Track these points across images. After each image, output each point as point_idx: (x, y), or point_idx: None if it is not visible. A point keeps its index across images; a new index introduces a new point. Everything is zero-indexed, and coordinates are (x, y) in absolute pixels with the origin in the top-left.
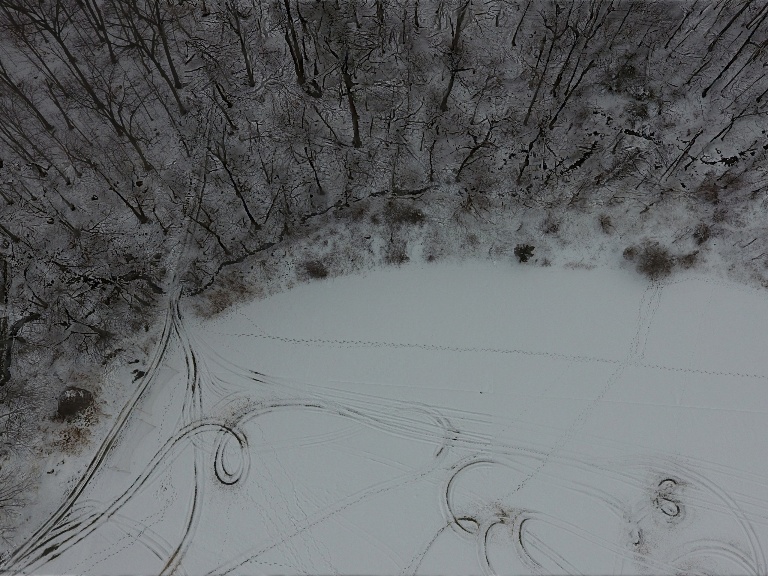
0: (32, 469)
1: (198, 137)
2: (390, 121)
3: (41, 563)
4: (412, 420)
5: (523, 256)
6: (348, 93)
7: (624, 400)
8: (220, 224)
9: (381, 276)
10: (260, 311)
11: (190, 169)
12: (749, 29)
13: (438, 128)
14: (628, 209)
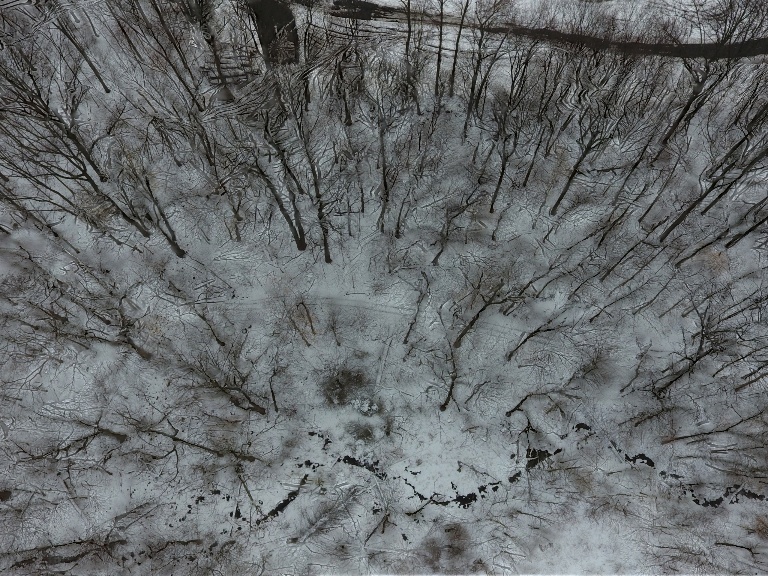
0: None
1: None
2: None
3: None
4: None
5: None
6: None
7: None
8: None
9: None
10: None
11: None
12: (507, 315)
13: (107, 471)
14: None
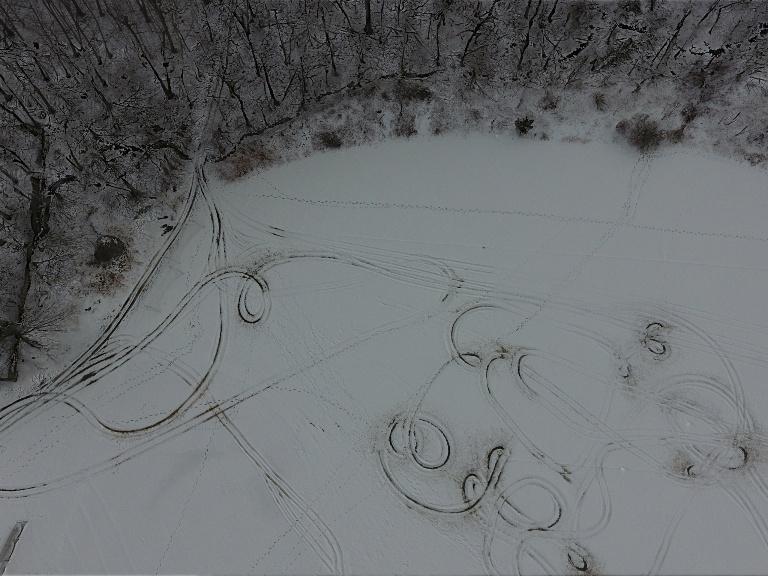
0: (71, 307)
1: (220, 24)
2: (400, 11)
3: (80, 387)
4: (420, 270)
5: (523, 129)
6: None
7: (615, 255)
8: None
9: (391, 147)
10: (279, 176)
11: None
12: None
13: (444, 18)
14: (621, 89)
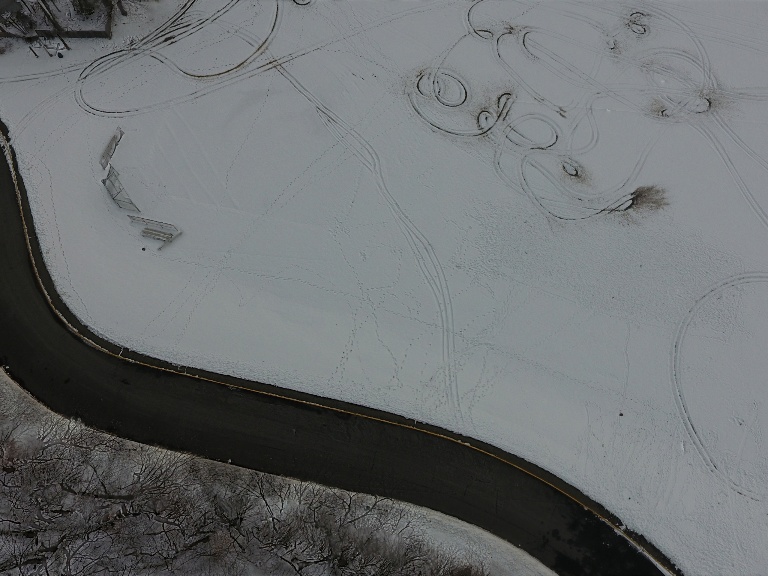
0: None
1: None
2: None
3: (163, 46)
4: None
5: None
6: None
7: None
8: None
9: None
10: None
11: None
12: None
13: None
14: None
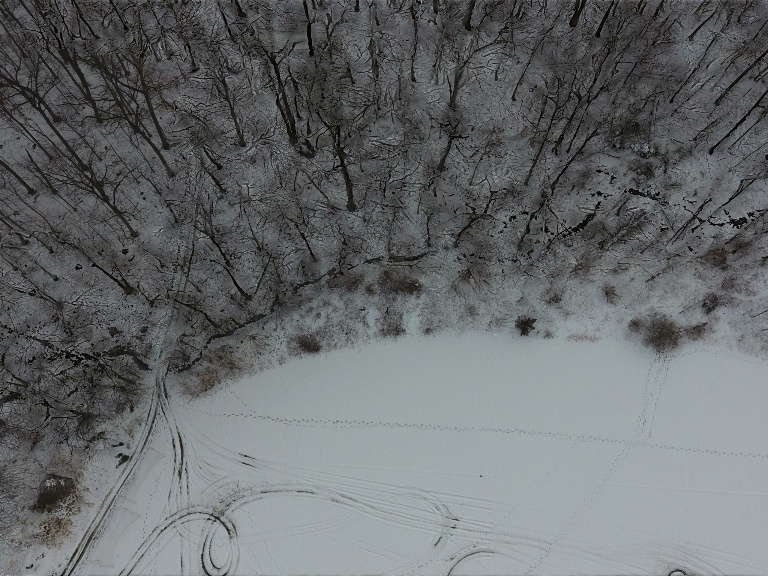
0: (10, 564)
1: None
2: (386, 183)
3: None
4: (409, 507)
5: (524, 328)
6: (341, 166)
7: (630, 483)
8: (209, 295)
9: (376, 350)
10: (250, 389)
11: (178, 236)
12: (757, 82)
13: (435, 190)
14: (633, 277)
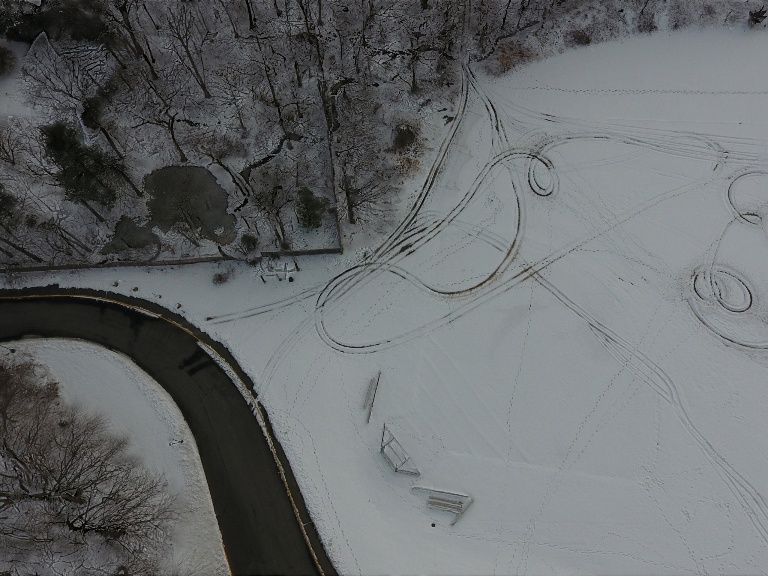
0: None
1: None
2: None
3: (401, 257)
4: (687, 145)
5: (756, 20)
6: None
7: None
8: (491, 7)
9: (636, 42)
10: (539, 70)
11: None
12: None
13: None
14: None
